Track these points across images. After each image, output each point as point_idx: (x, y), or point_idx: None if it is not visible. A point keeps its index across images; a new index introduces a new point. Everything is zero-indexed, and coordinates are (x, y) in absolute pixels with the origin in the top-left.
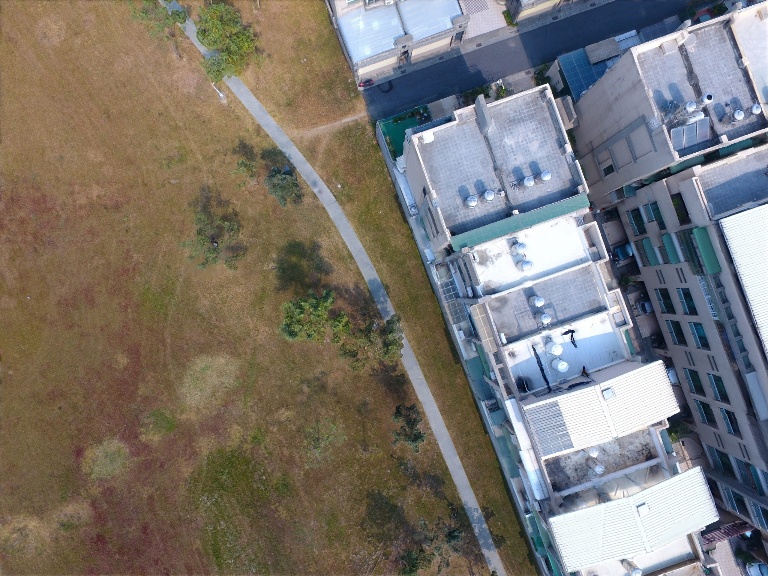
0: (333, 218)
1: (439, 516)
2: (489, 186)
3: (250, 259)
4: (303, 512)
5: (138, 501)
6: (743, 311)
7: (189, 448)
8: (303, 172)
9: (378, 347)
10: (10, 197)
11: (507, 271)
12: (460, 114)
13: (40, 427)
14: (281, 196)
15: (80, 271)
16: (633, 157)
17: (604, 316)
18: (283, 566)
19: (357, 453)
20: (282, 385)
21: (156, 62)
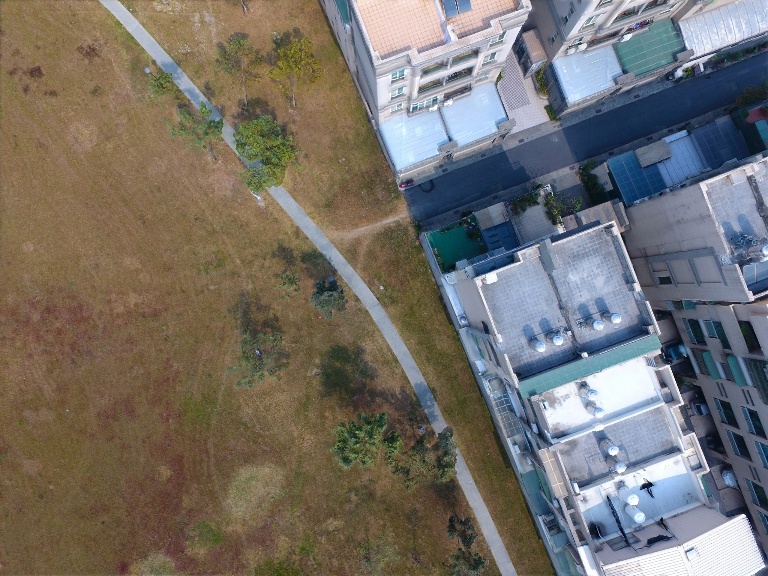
0: (376, 321)
1: None
2: (554, 324)
3: (293, 365)
4: None
5: None
6: None
7: (236, 561)
8: (344, 275)
9: (432, 465)
10: (46, 308)
11: (576, 413)
12: (523, 253)
13: (83, 543)
14: (327, 309)
15: (119, 382)
16: (697, 280)
17: (677, 457)
18: None
19: (408, 562)
20: (329, 494)
21: (191, 165)
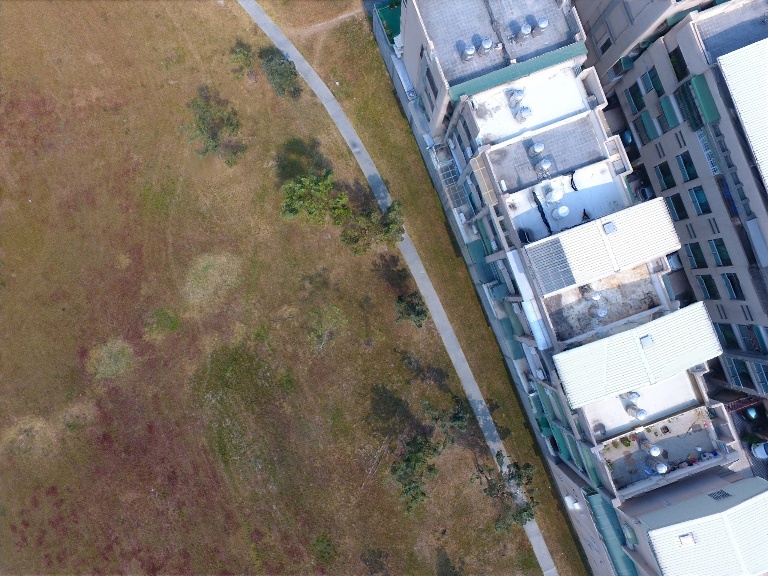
0: (332, 115)
1: (443, 409)
2: None
3: (250, 158)
4: (308, 408)
5: (143, 400)
6: (743, 154)
7: (193, 346)
8: (301, 70)
9: (379, 230)
10: (10, 101)
11: (506, 124)
12: None
13: (44, 329)
14: (279, 85)
15: (81, 173)
16: (630, 19)
17: (604, 166)
18: (289, 462)
19: (360, 348)
20: (284, 282)
21: None
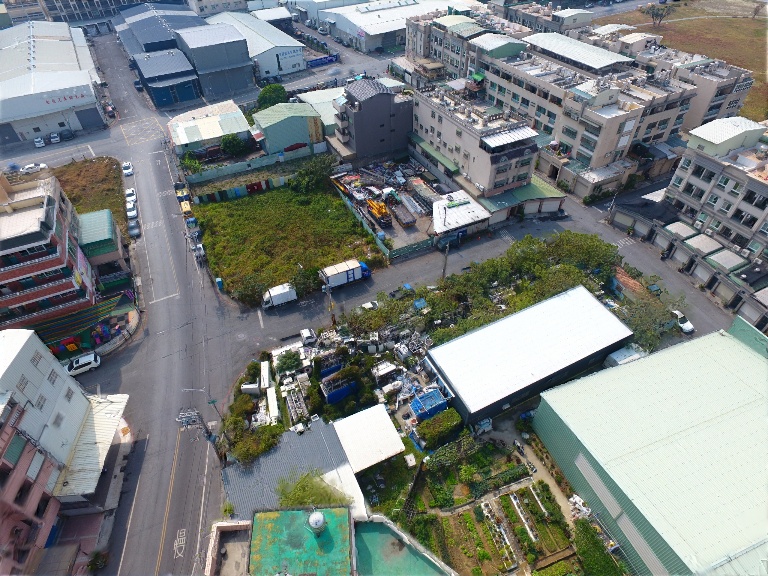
0: None
1: None
2: None
3: None
4: None
5: None
6: None
7: None
8: None
9: None
10: None
11: None
12: None
13: None
14: None
15: None
16: None
17: None
18: None
19: None
20: None
21: None
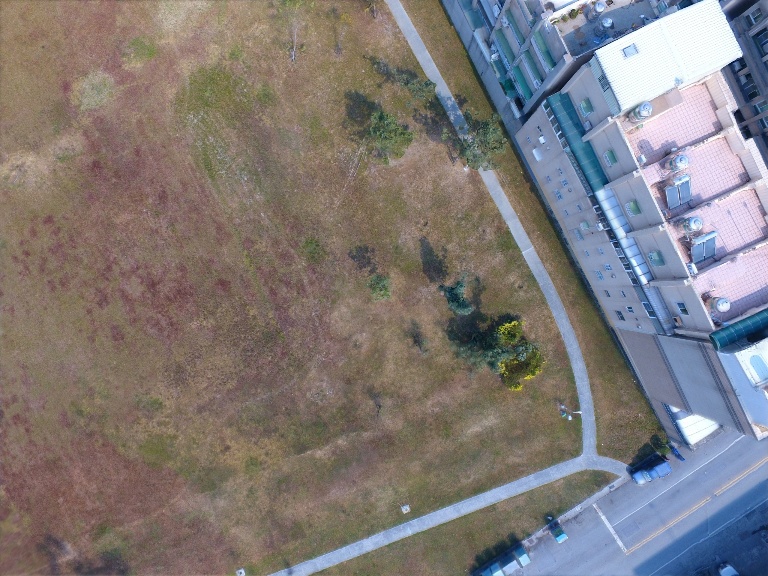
0: None
1: (415, 108)
2: None
3: None
4: (286, 118)
5: (128, 126)
6: None
7: (171, 71)
8: None
9: None
10: None
11: None
12: None
13: (26, 67)
14: None
15: None
16: None
17: None
18: (272, 171)
19: (331, 57)
20: (253, 1)
21: None
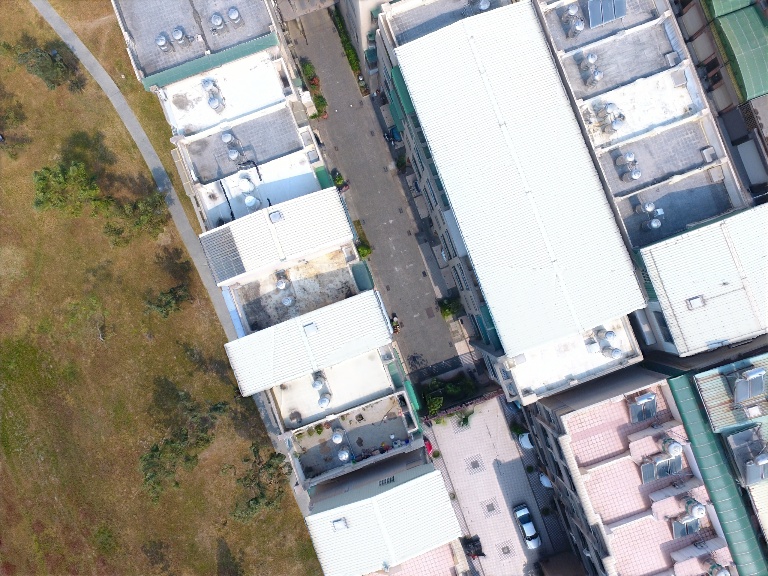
0: (117, 108)
1: (225, 401)
2: (190, 32)
3: (35, 150)
4: (90, 400)
5: None
6: None
7: None
8: (87, 63)
9: None
10: None
11: (207, 115)
12: None
13: None
14: (46, 78)
15: None
16: (353, 11)
17: (303, 157)
18: (71, 453)
19: (143, 340)
20: (68, 275)
21: None
